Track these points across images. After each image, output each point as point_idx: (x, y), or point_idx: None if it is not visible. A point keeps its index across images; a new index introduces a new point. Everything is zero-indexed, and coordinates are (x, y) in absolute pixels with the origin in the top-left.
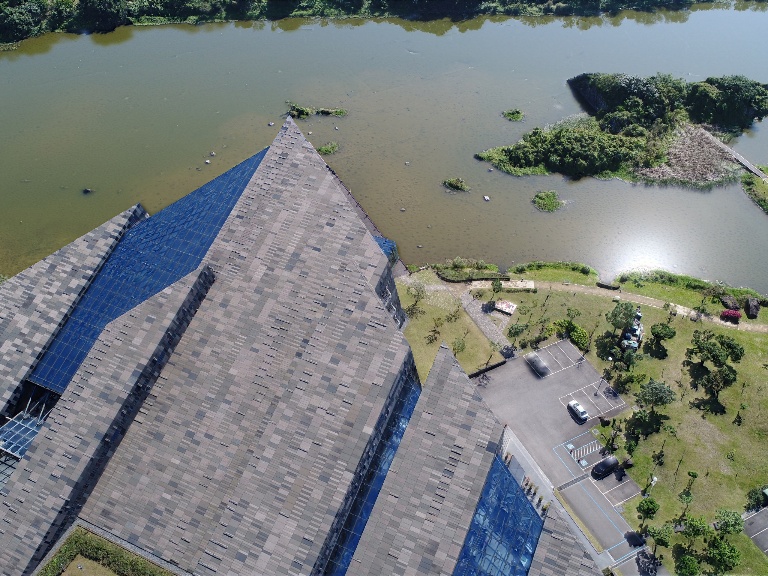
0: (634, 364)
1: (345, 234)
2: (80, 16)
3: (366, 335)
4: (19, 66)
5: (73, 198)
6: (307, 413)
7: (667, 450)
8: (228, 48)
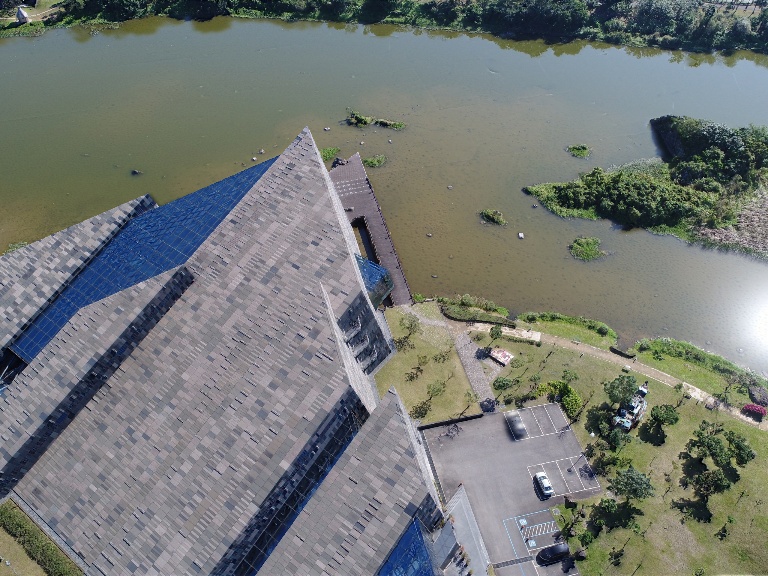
0: (619, 445)
1: (327, 255)
2: (184, 2)
3: (310, 365)
4: (116, 45)
5: (121, 177)
6: (232, 434)
7: (628, 550)
8: (311, 48)
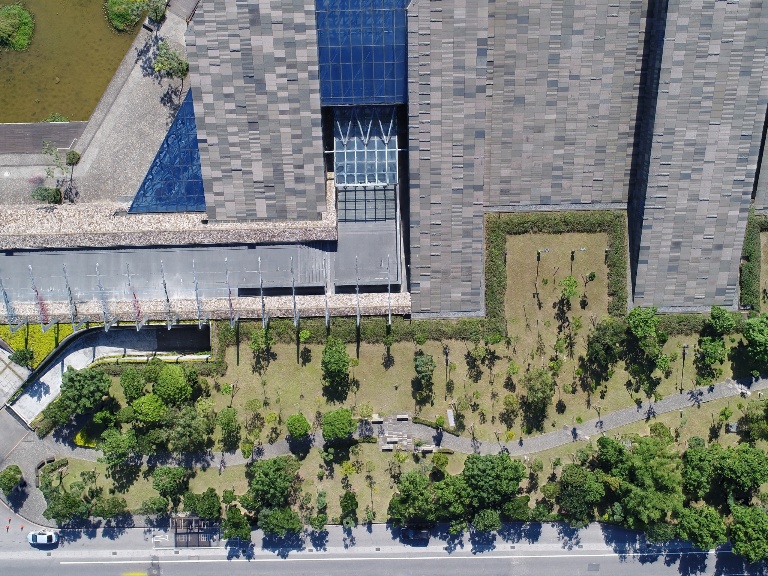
0: None
1: None
2: None
3: None
4: None
5: None
6: (705, 13)
7: None
8: None
